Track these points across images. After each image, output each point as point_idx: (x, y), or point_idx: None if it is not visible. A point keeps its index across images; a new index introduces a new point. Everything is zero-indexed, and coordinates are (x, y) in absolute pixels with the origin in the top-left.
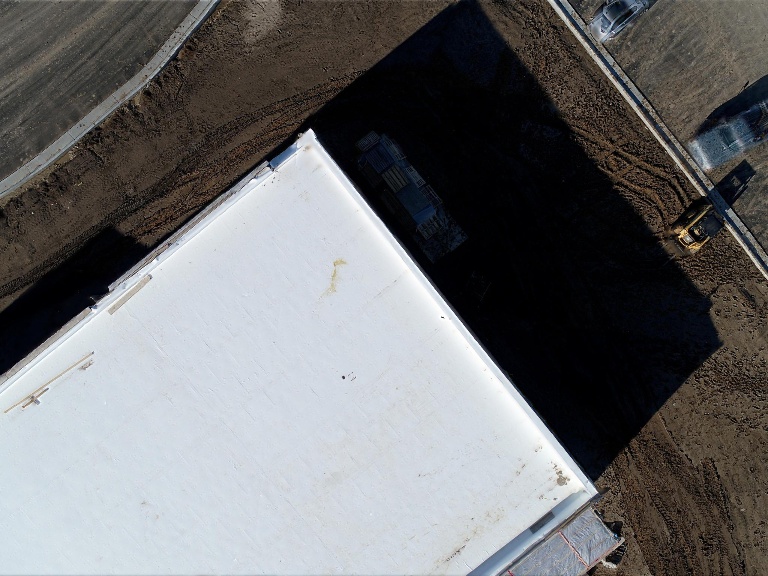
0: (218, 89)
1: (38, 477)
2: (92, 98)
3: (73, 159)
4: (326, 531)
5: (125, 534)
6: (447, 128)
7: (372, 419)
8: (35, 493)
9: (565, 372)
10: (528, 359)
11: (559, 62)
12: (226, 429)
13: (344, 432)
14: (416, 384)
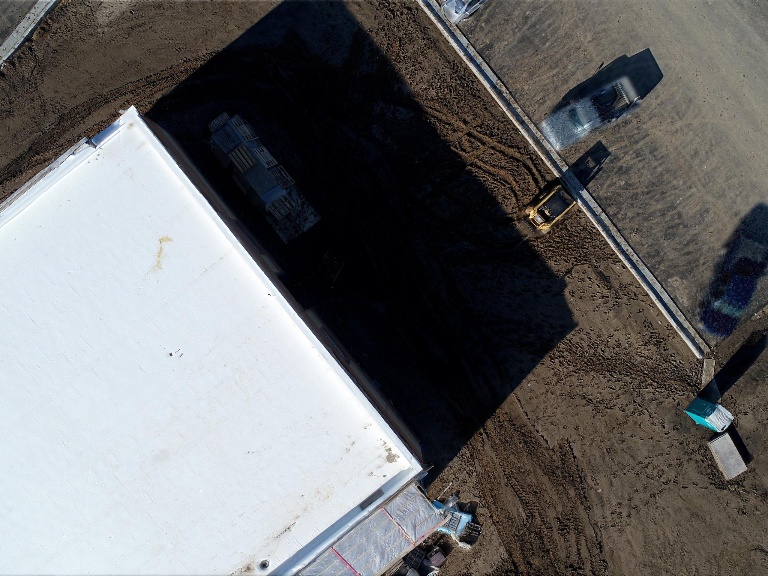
0: (71, 70)
1: None
2: None
3: None
4: (155, 508)
5: None
6: (300, 109)
7: (200, 396)
8: None
9: (419, 353)
10: (382, 340)
11: (413, 43)
12: (54, 406)
13: (172, 409)
14: (244, 361)
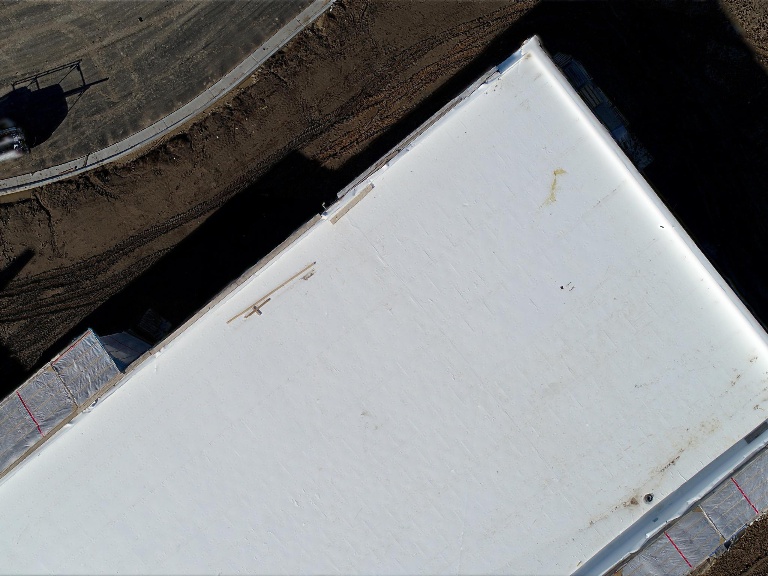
0: (403, 11)
1: (259, 388)
2: (275, 21)
3: (257, 83)
4: (543, 442)
5: (344, 445)
6: (633, 49)
7: (590, 329)
8: (256, 404)
9: (749, 295)
10: None
11: None
12: (445, 340)
13: (562, 342)
14: (634, 294)
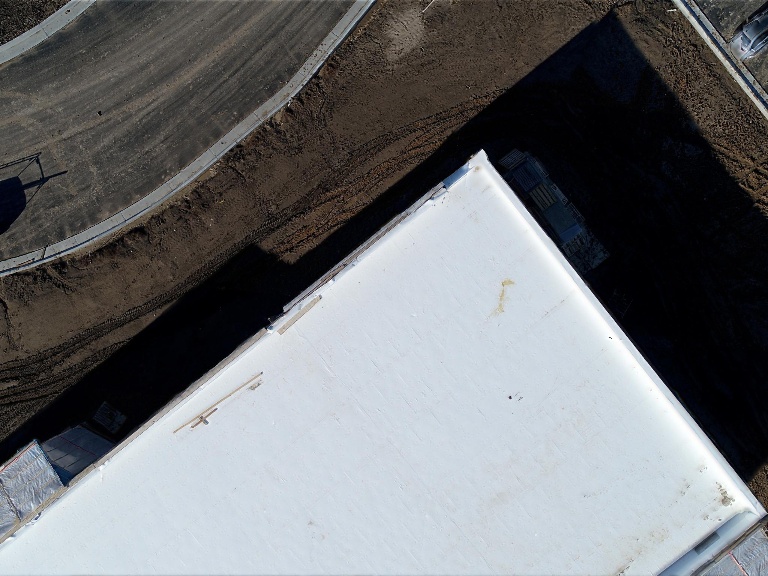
0: (360, 107)
1: (205, 497)
2: (234, 116)
3: (215, 176)
4: (491, 552)
5: (291, 555)
6: (589, 146)
7: (538, 439)
8: (202, 514)
9: (706, 390)
10: (669, 377)
11: (699, 80)
12: (393, 449)
13: (510, 452)
14: (583, 404)
